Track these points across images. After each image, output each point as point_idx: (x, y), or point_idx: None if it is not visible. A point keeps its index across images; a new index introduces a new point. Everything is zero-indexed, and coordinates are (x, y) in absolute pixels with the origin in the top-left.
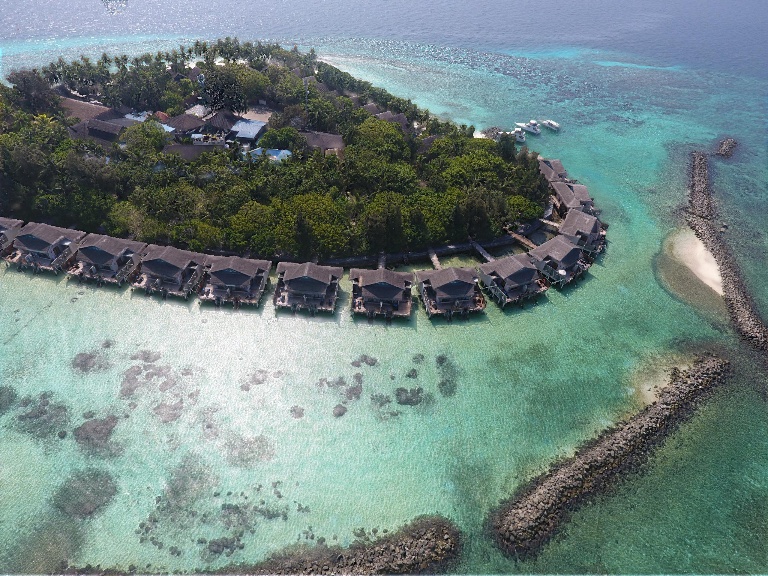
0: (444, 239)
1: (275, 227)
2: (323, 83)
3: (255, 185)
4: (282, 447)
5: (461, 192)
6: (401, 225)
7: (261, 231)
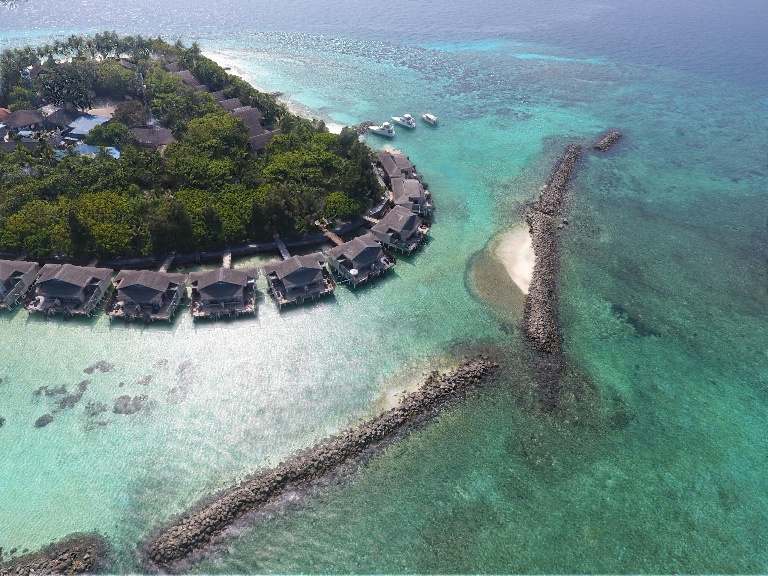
0: (244, 238)
1: (54, 227)
2: (195, 77)
3: (43, 183)
4: None
5: None
6: (194, 224)
7: (38, 231)
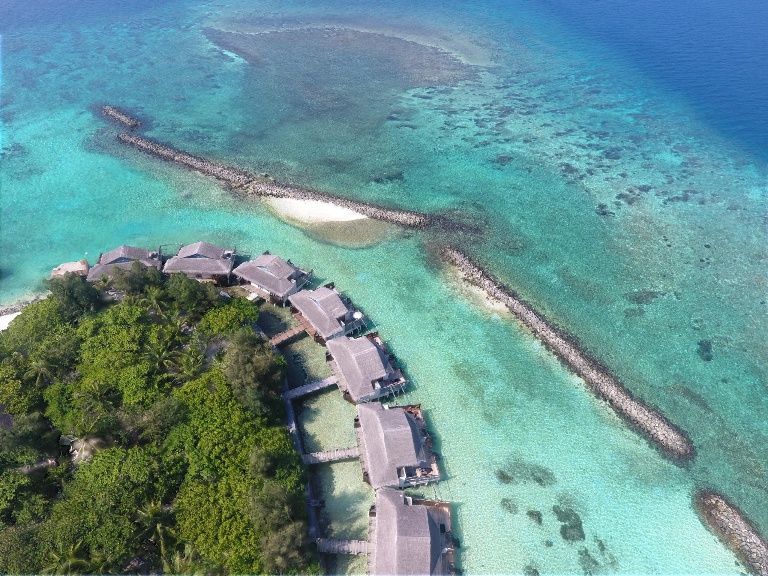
0: None
1: None
2: None
3: None
4: None
5: (197, 384)
6: None
7: None
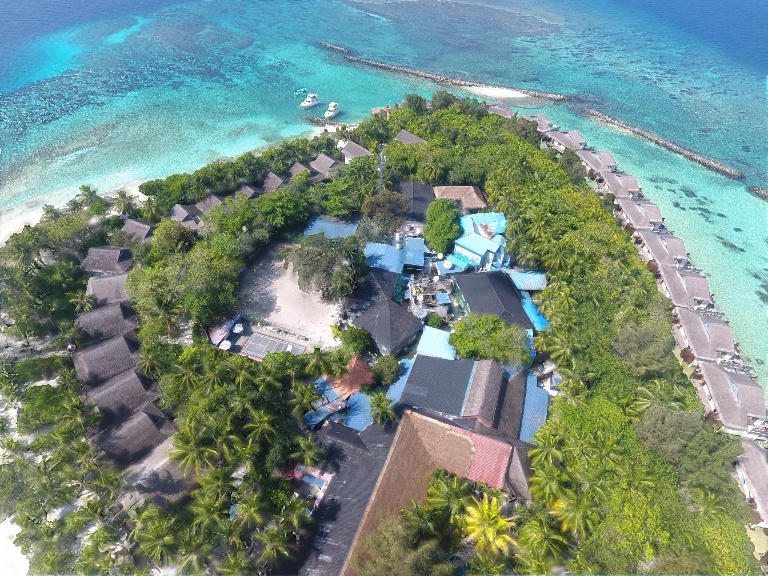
0: None
1: None
2: (214, 196)
3: None
4: (764, 234)
5: None
6: None
7: None
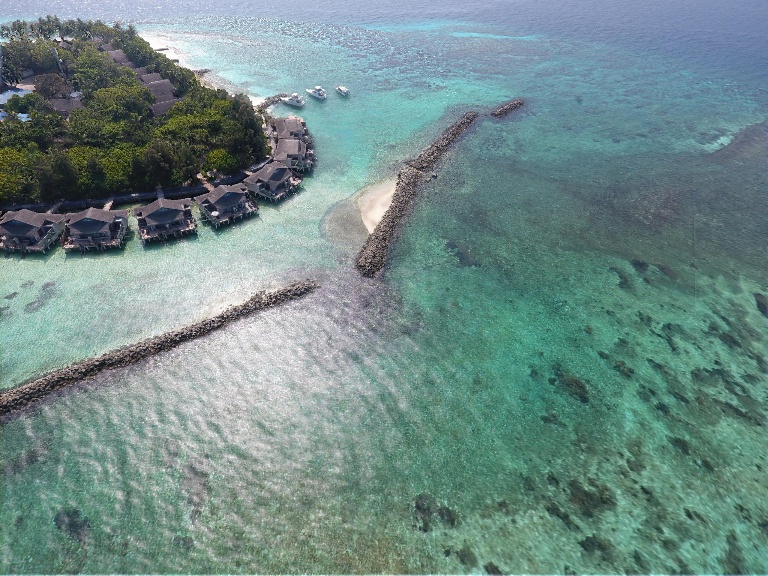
0: (127, 188)
1: None
2: (124, 56)
3: None
4: None
5: None
6: (80, 175)
7: None
